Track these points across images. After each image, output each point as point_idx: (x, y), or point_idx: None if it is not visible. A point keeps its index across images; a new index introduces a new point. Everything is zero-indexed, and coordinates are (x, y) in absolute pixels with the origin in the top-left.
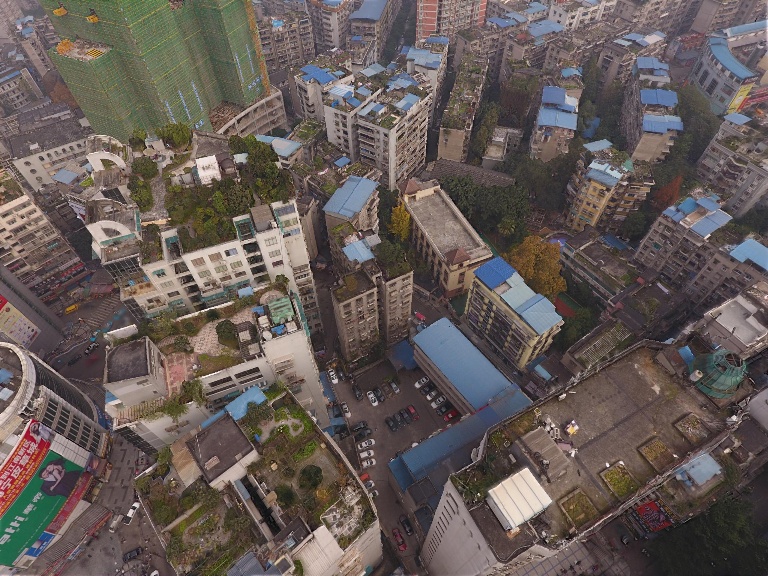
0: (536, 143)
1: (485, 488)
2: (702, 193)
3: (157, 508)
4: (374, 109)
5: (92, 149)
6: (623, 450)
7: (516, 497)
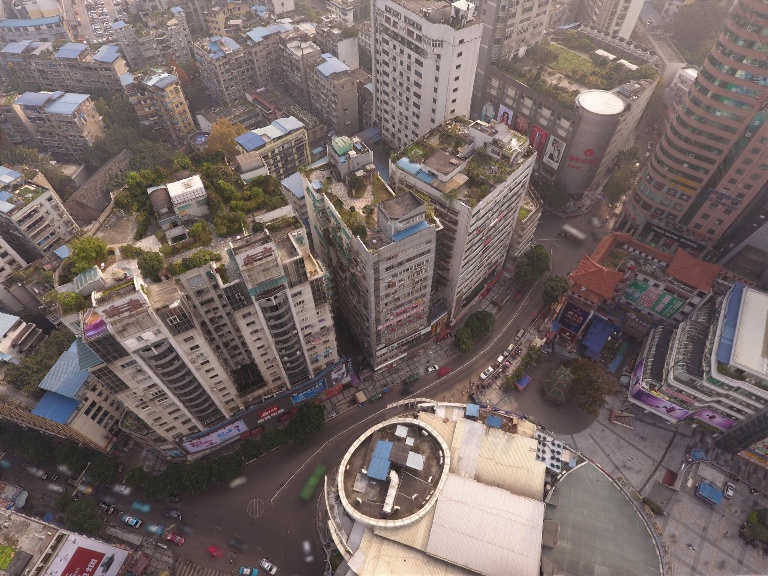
0: (82, 130)
1: (459, 22)
2: (201, 42)
3: (483, 191)
4: (5, 199)
5: (121, 297)
6: (429, 3)
7: (464, 5)
